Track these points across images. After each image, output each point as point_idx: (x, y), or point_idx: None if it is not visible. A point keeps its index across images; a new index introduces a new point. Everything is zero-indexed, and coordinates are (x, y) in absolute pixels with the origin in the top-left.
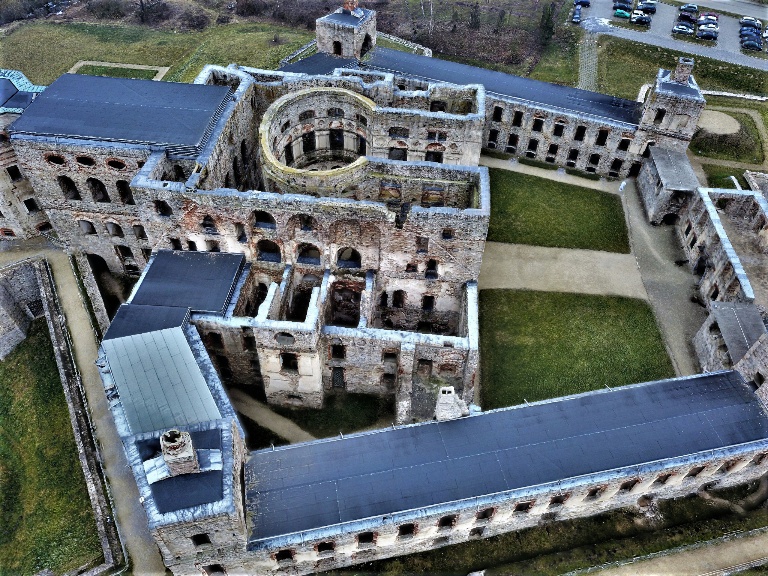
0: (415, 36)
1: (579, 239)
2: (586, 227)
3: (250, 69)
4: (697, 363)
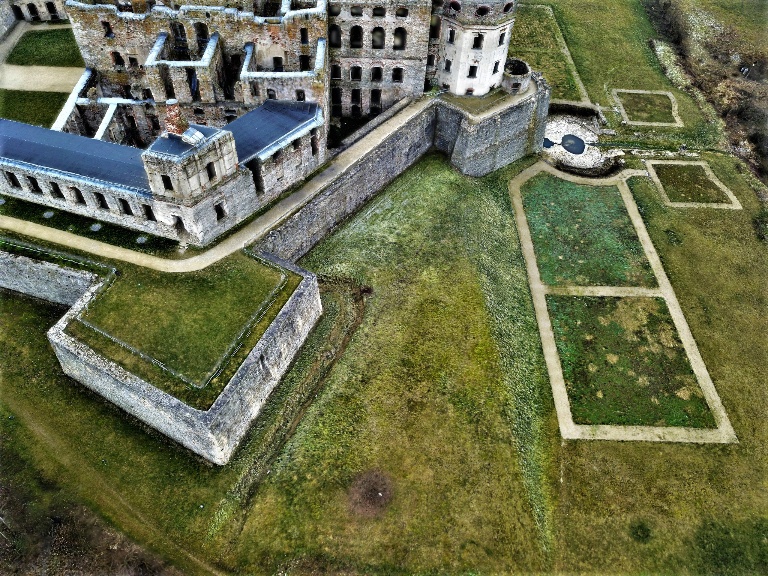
0: (38, 568)
1: (22, 96)
2: (7, 105)
3: (302, 73)
4: (5, 36)
